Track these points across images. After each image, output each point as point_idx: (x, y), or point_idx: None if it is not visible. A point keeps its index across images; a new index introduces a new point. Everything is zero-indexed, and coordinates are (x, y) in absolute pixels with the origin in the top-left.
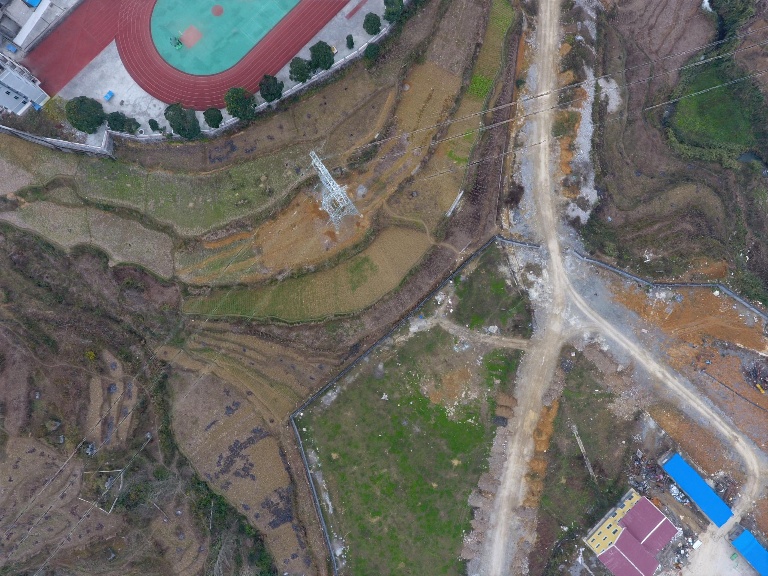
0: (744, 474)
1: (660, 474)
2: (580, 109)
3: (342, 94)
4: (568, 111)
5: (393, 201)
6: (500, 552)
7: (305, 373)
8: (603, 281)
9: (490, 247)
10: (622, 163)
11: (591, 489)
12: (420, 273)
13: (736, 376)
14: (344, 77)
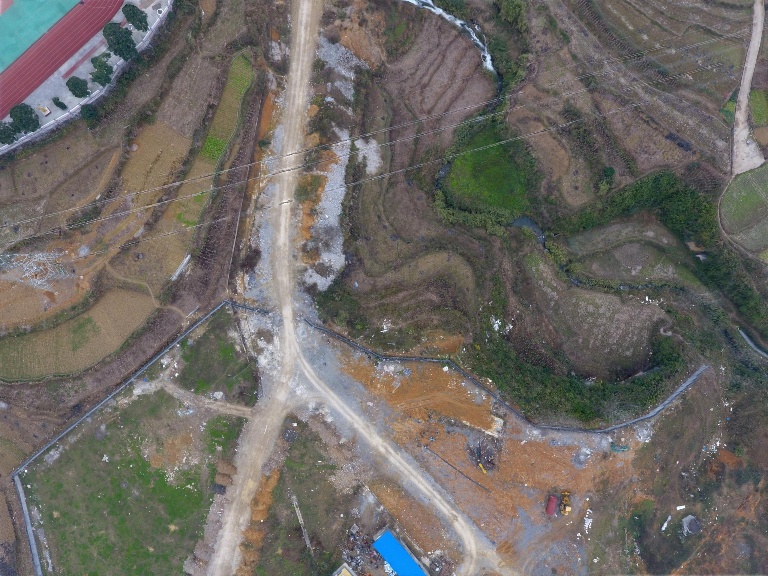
0: (461, 554)
1: (374, 550)
2: (326, 172)
3: (64, 153)
4: (312, 174)
5: (118, 263)
6: None
7: (29, 431)
8: (333, 351)
9: (220, 312)
10: (378, 227)
11: (307, 561)
12: (145, 336)
13: (460, 454)
14: (64, 137)
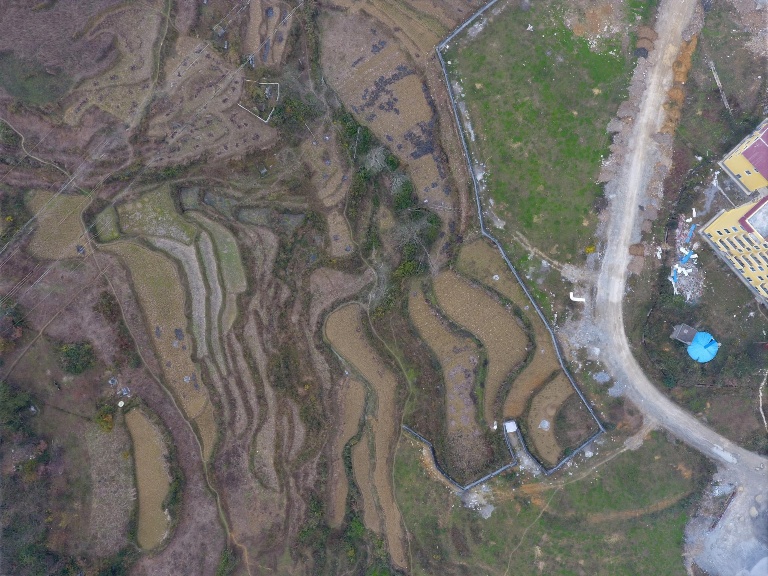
0: None
1: None
2: None
3: None
4: None
5: None
6: (637, 175)
7: (453, 5)
8: None
9: None
10: None
11: (726, 121)
12: None
13: None
14: None
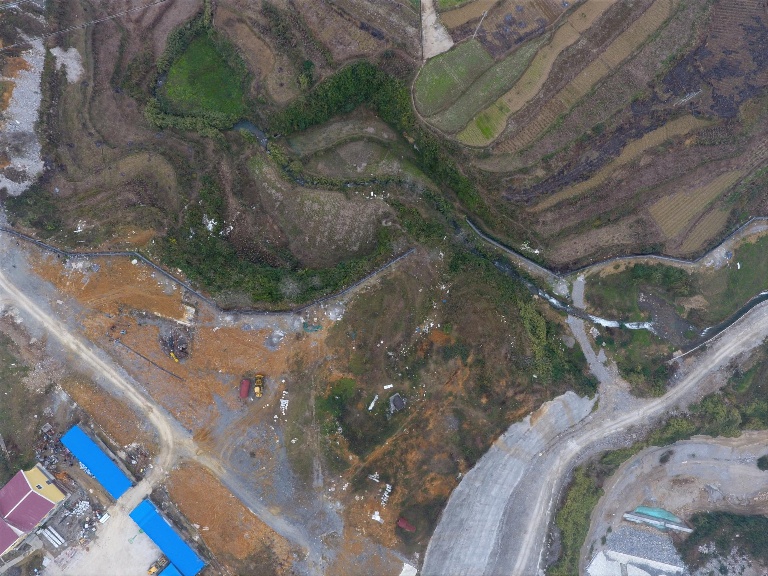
0: (157, 445)
1: (66, 447)
2: (13, 78)
3: None
4: None
5: None
6: None
7: None
8: (22, 253)
9: None
10: (82, 133)
11: (3, 465)
12: None
13: (153, 345)
14: None
